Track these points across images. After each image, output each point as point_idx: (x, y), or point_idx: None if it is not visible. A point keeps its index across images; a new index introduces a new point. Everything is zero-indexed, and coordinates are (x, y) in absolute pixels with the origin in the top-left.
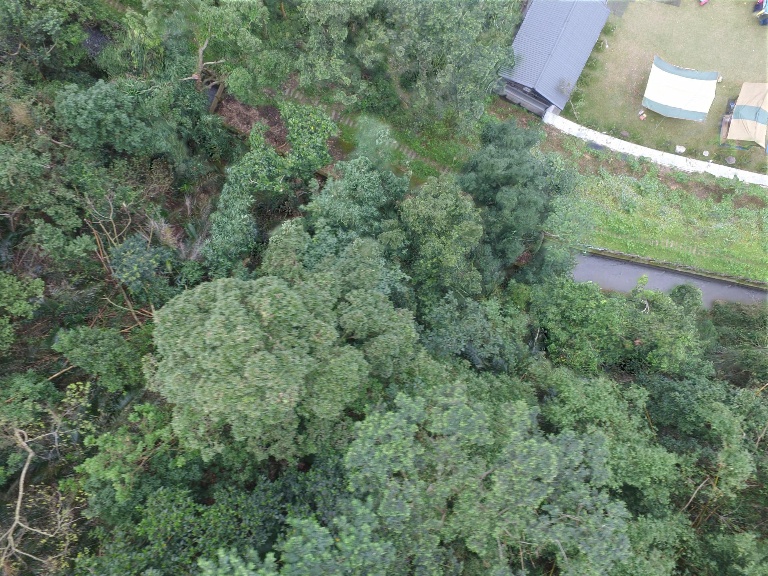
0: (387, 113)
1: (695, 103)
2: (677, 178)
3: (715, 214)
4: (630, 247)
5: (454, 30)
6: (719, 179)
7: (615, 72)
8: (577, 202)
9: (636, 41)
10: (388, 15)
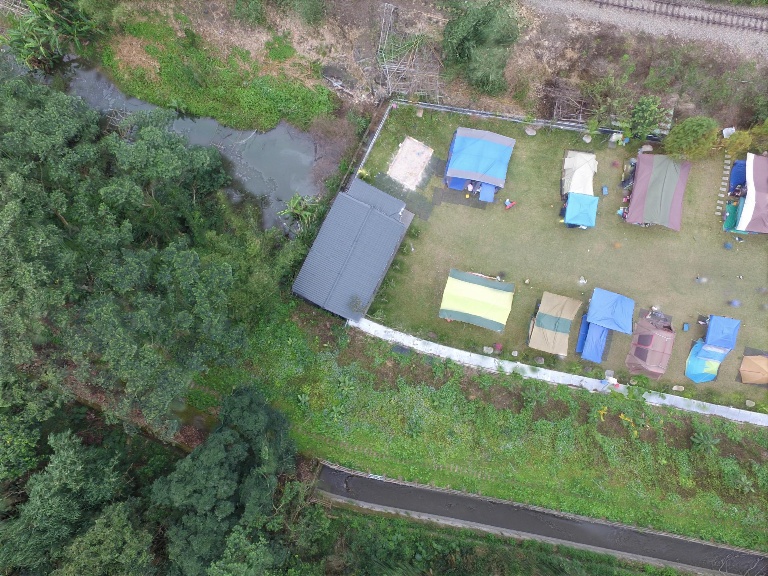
0: (166, 342)
1: (494, 313)
2: (480, 384)
3: (506, 432)
4: (413, 472)
5: (129, 366)
6: (526, 381)
7: (421, 274)
8: (359, 428)
9: (442, 244)
10: (66, 348)
